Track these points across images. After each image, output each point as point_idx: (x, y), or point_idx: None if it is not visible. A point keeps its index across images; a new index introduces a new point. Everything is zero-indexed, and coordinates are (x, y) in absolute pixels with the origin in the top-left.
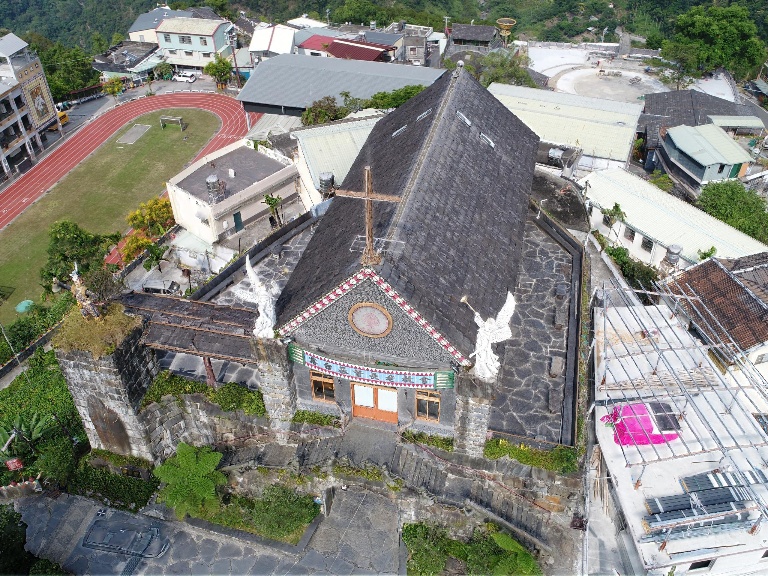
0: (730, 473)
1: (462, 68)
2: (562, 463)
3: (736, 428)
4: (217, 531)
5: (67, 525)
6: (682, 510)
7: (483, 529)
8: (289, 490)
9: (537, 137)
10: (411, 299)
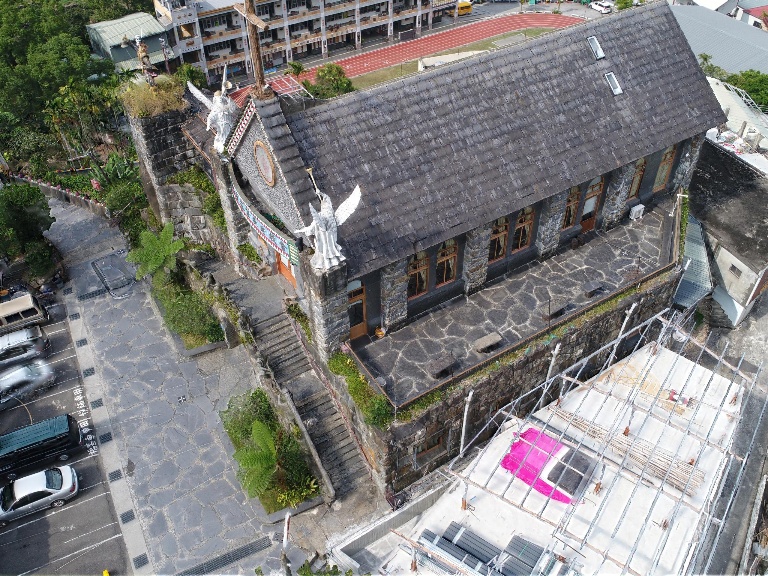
0: (575, 572)
1: (663, 0)
2: (365, 409)
3: (651, 546)
4: (158, 306)
5: (98, 246)
6: (468, 554)
7: (293, 429)
8: (204, 302)
9: (722, 118)
10: (280, 150)
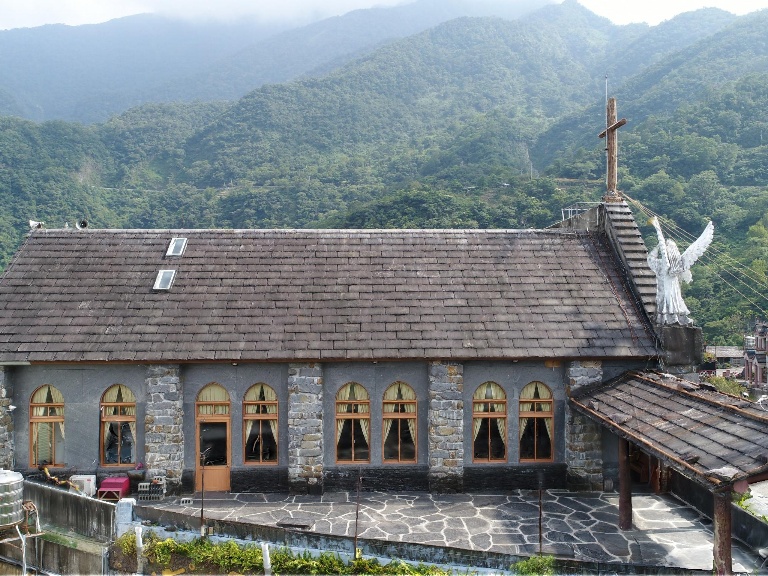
0: None
1: None
2: None
3: None
4: None
5: None
6: None
7: None
8: None
9: None
10: None
